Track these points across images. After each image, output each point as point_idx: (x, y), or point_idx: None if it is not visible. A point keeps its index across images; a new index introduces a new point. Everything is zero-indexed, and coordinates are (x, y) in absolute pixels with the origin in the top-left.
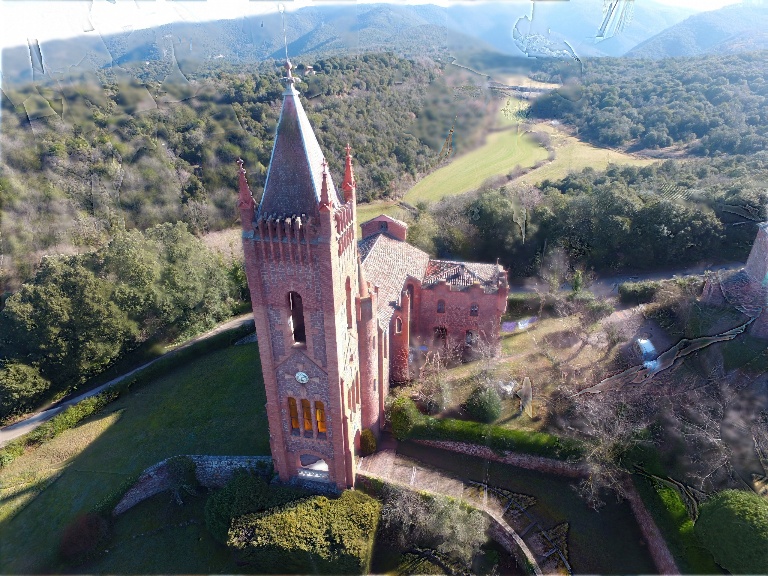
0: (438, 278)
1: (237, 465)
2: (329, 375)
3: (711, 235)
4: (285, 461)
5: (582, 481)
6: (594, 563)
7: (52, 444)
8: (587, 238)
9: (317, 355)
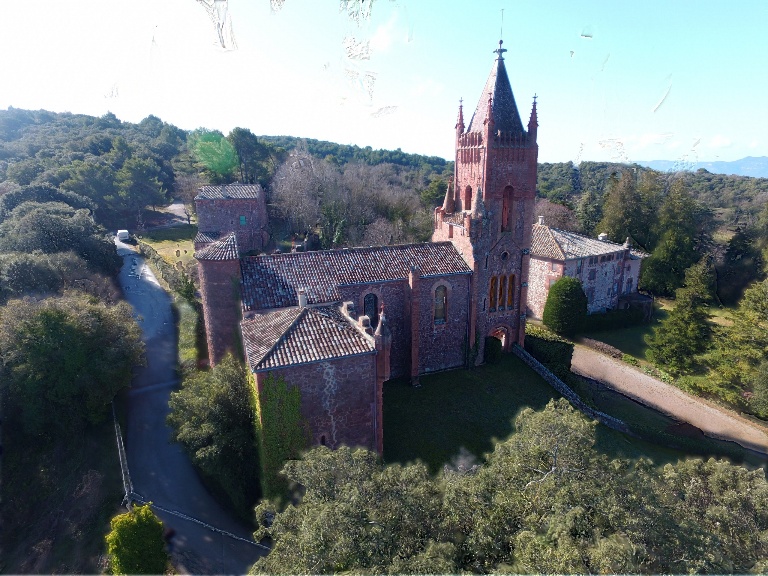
0: None
1: None
2: None
3: None
4: None
5: None
6: None
7: None
8: None
9: None
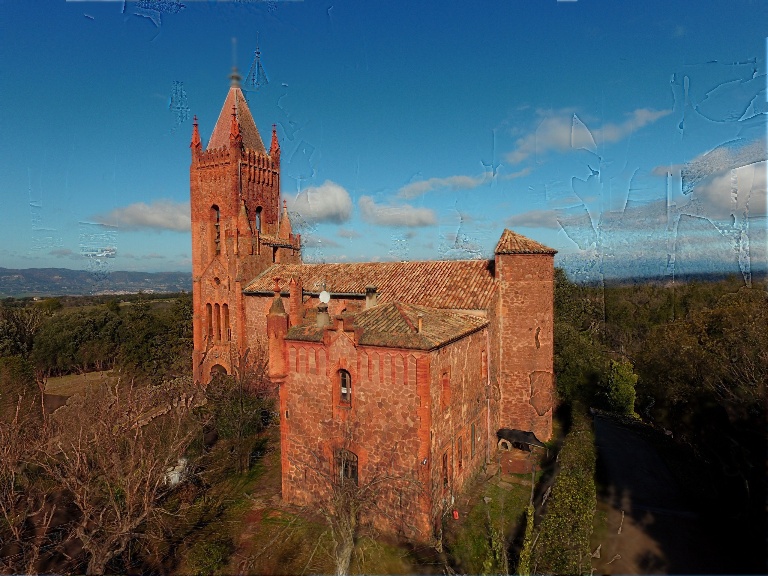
0: None
1: None
2: None
3: None
4: None
5: None
6: None
7: None
8: None
9: None
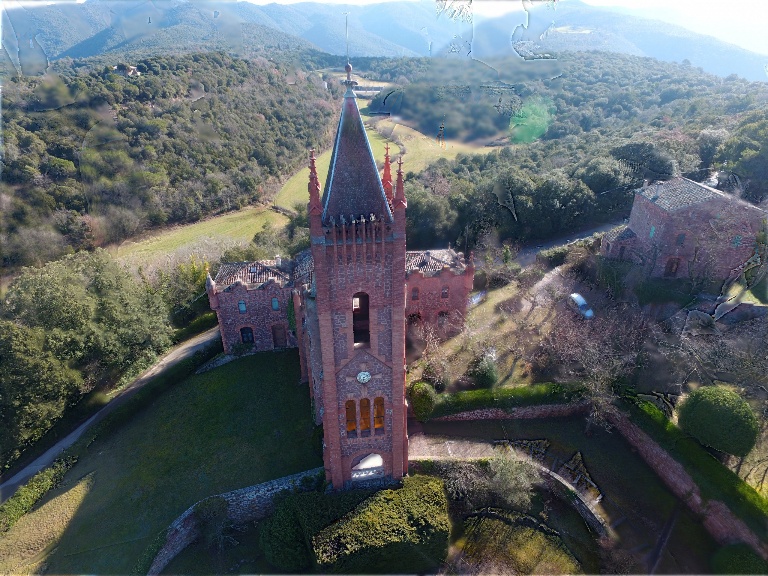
0: (408, 268)
1: (278, 489)
2: (394, 368)
3: (588, 204)
4: (341, 467)
5: (591, 413)
6: (610, 476)
7: (10, 538)
8: (497, 218)
9: (381, 351)
